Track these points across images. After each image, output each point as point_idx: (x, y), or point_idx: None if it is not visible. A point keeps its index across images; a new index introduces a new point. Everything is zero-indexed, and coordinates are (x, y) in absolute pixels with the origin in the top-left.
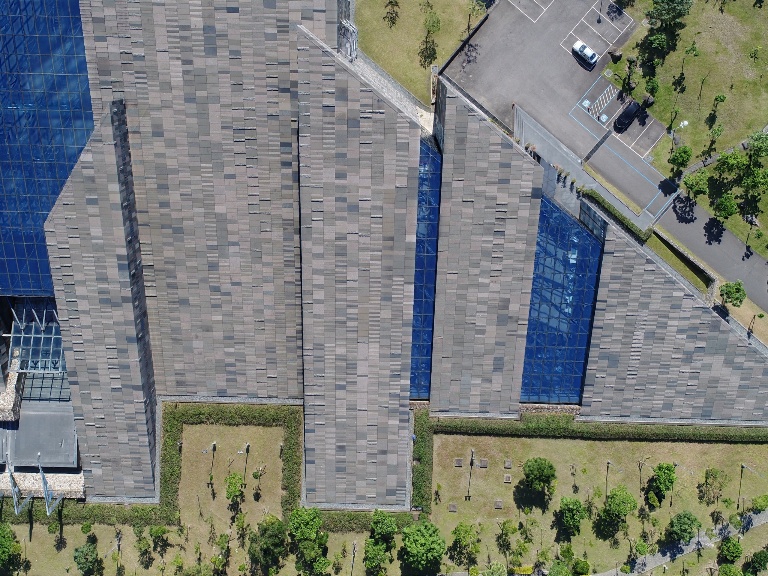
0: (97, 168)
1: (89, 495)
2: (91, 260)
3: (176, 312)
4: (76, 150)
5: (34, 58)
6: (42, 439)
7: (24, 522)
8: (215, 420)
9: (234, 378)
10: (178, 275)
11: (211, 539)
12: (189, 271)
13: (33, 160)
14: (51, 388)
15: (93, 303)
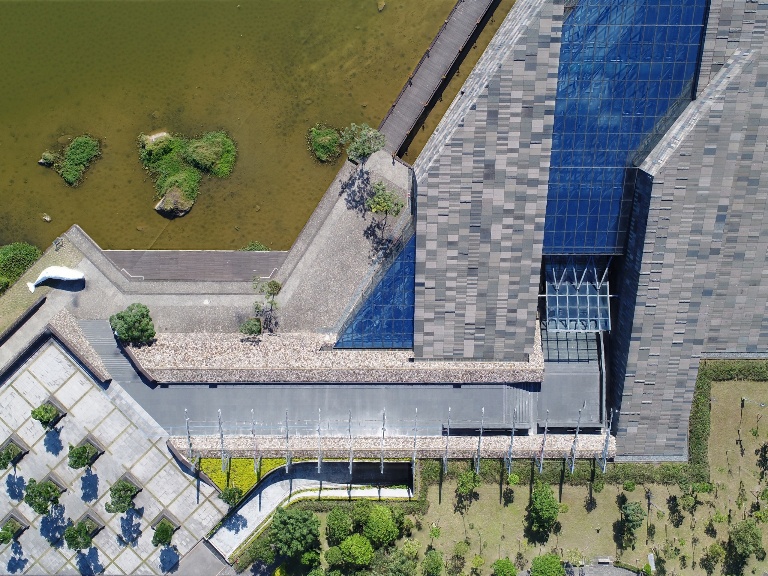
0: (725, 117)
1: (616, 455)
2: (691, 212)
3: (728, 267)
4: (668, 103)
5: (652, 9)
6: (564, 400)
7: (553, 483)
8: (745, 376)
9: (767, 333)
10: (741, 228)
11: (740, 496)
12: (753, 224)
13: (622, 114)
14: (567, 349)
15: (679, 256)
